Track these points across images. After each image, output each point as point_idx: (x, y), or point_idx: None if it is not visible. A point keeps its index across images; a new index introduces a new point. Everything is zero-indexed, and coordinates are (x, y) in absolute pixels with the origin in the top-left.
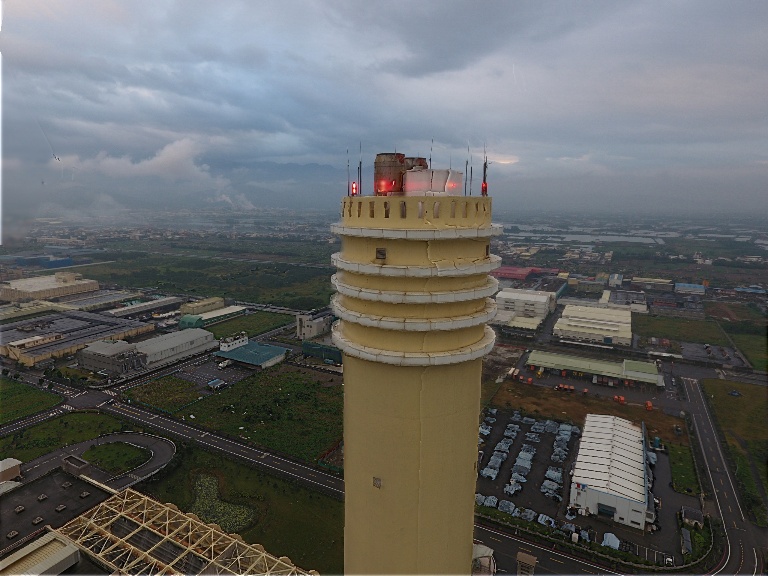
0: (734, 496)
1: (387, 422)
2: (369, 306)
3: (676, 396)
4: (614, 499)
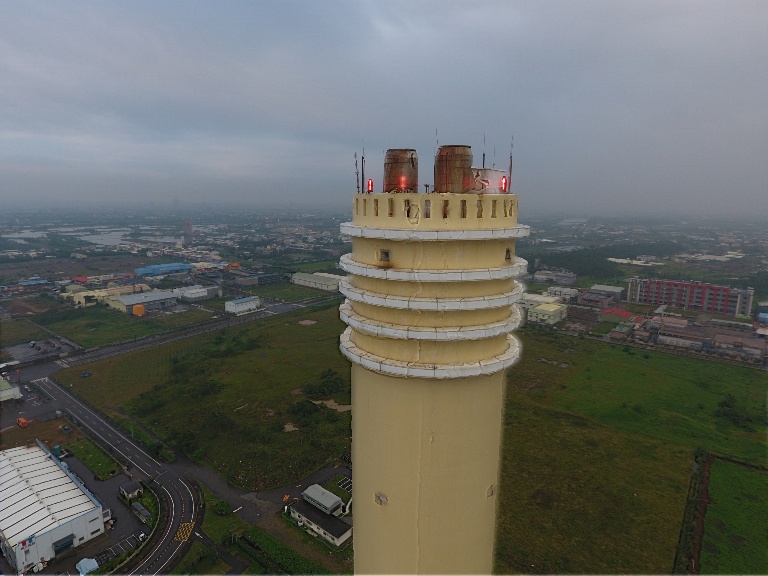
0: (143, 453)
1: (497, 422)
2: (500, 311)
3: (40, 401)
4: (68, 526)
